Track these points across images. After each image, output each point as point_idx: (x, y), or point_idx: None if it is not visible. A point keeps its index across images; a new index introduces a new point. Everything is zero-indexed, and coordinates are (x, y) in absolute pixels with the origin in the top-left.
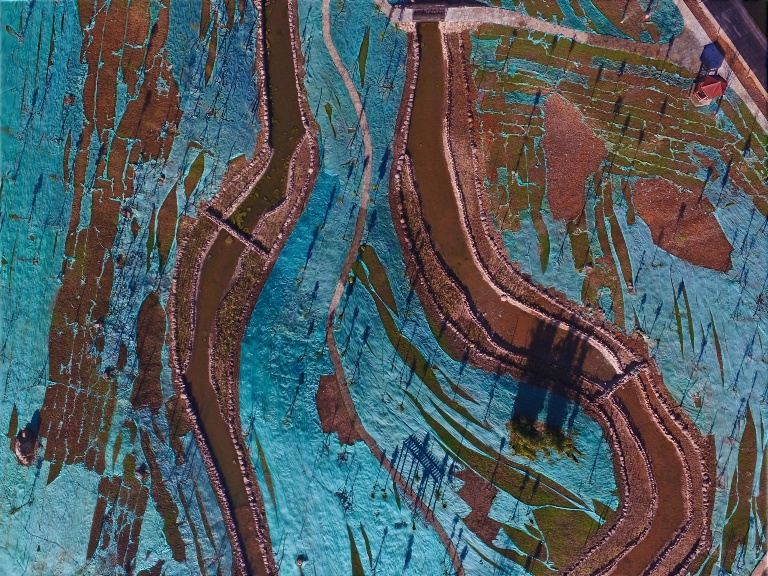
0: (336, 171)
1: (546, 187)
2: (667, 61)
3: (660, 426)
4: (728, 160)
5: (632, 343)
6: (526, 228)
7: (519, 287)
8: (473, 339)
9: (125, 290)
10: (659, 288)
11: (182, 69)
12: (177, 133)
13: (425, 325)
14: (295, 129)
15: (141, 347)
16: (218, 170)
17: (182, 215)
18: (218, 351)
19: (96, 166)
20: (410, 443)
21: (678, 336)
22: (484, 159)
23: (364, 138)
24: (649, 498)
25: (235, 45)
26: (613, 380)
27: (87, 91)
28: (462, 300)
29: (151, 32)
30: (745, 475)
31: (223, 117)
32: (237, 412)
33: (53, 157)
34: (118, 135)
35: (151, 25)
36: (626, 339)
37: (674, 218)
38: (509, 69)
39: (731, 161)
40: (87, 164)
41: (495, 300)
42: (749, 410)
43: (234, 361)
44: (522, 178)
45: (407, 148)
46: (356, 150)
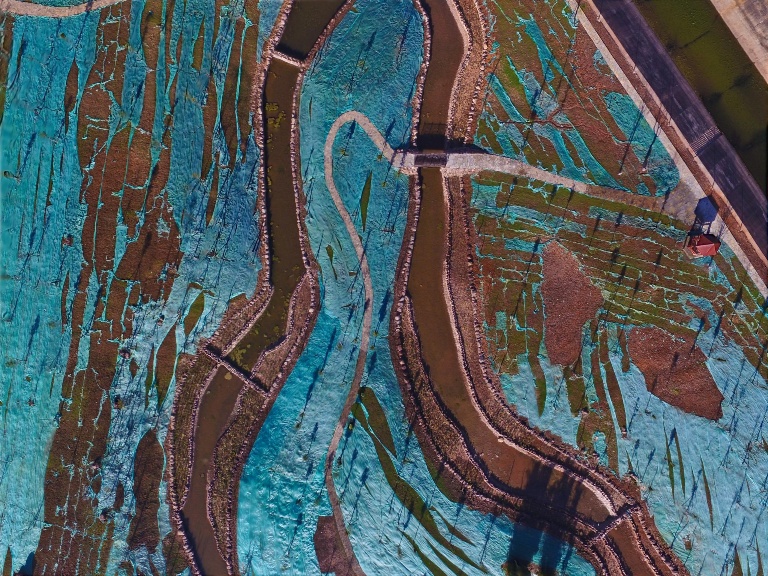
0: (337, 313)
1: (544, 333)
2: (663, 213)
3: (651, 567)
4: (720, 311)
5: (625, 486)
6: (523, 372)
7: (516, 429)
8: (470, 480)
9: (123, 430)
10: (652, 434)
11: (183, 211)
12: (177, 274)
13: (423, 466)
14: (296, 267)
15: (138, 486)
16: (218, 309)
17: (181, 353)
18: (216, 488)
19: (94, 308)
20: None
21: (670, 481)
22: (483, 303)
23: (365, 281)
24: None
25: (237, 185)
26: (606, 521)
27: (86, 232)
28: (460, 441)
29: (152, 173)
30: None
31: (224, 257)
32: (234, 549)
33: (50, 298)
34: (117, 276)
35: (152, 166)
36: (619, 482)
37: (667, 366)
38: (509, 216)
39: (723, 312)
40: (85, 306)
41: (492, 441)
42: (737, 554)
43: (232, 499)
44: (520, 323)
45: (407, 289)
46: (357, 293)
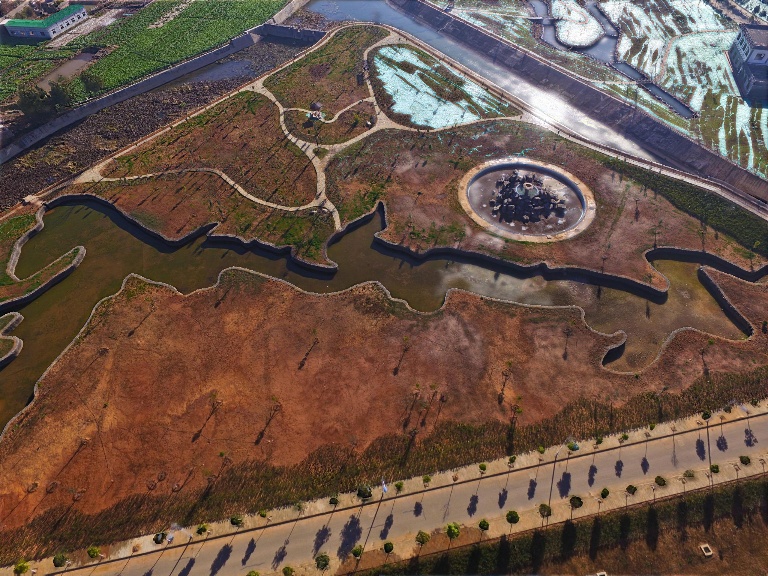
0: None
1: None
2: None
3: None
4: None
5: None
6: None
7: None
8: None
9: None
10: None
11: None
12: None
13: None
14: (588, 8)
15: None
16: None
17: None
18: None
19: None
20: None
21: None
22: None
23: None
24: None
25: None
26: None
27: None
28: None
29: None
30: None
31: None
32: None
33: None
34: None
35: None
36: None
37: None
38: None
39: None
40: None
41: None
42: None
43: None
44: None
45: None
46: None
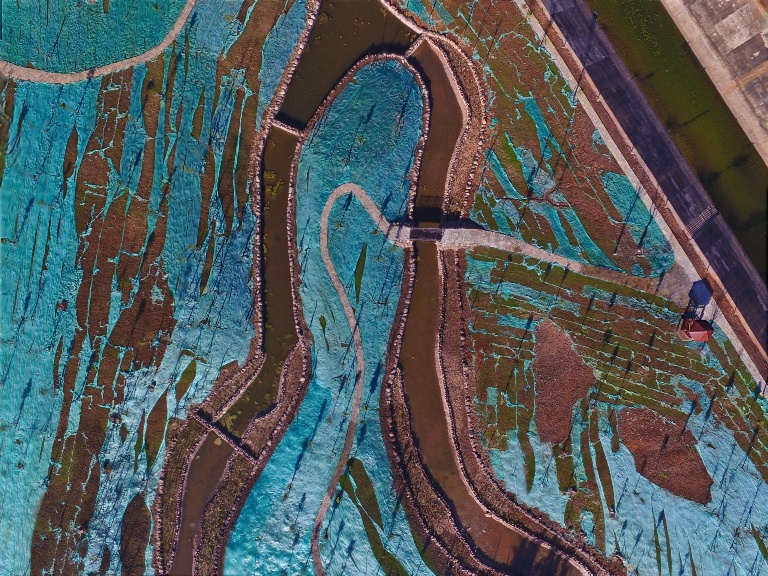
0: (328, 384)
1: (534, 410)
2: (657, 295)
3: None
4: (712, 395)
5: (612, 566)
6: (513, 448)
7: (504, 505)
8: (456, 555)
9: (111, 495)
10: (640, 515)
11: (178, 278)
12: (170, 341)
13: (410, 539)
14: (289, 335)
15: (125, 550)
16: (210, 375)
17: (172, 419)
18: (202, 553)
19: (87, 373)
20: None
21: (656, 563)
22: (475, 377)
23: (357, 353)
24: None
25: (232, 252)
26: None
27: (81, 297)
28: (447, 515)
29: (148, 241)
30: None
31: (217, 325)
32: None
33: (43, 362)
34: (110, 342)
35: (148, 233)
36: (606, 562)
37: (657, 448)
38: (503, 292)
39: (715, 396)
40: (78, 371)
41: (480, 515)
42: None
43: (218, 565)
44: (511, 399)
45: (399, 360)
46: (348, 364)
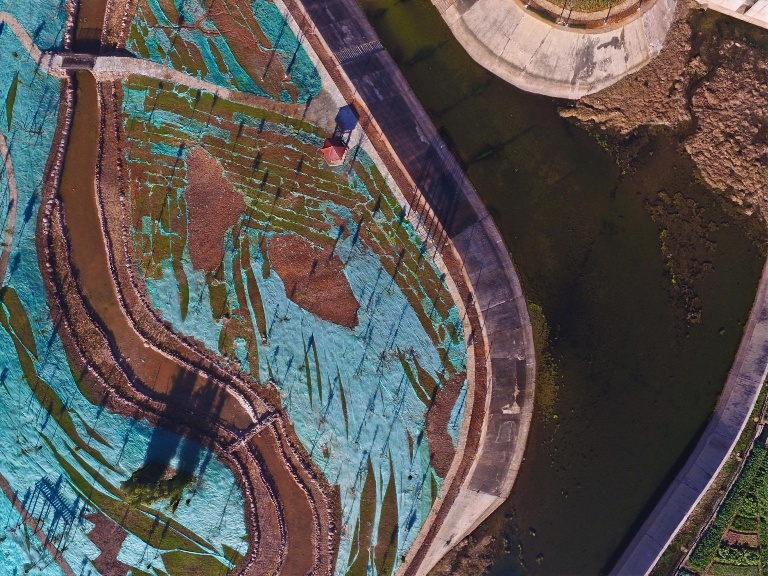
0: None
1: (187, 238)
2: (304, 121)
3: (292, 474)
4: (359, 220)
5: (266, 393)
6: (167, 277)
7: (161, 334)
8: (113, 384)
9: None
10: (291, 341)
11: None
12: None
13: (66, 368)
14: None
15: None
16: None
17: None
18: None
19: None
20: (42, 485)
21: (307, 388)
22: (131, 207)
23: (9, 181)
24: (279, 544)
25: None
26: (248, 428)
27: None
28: (105, 345)
29: None
30: (366, 525)
31: None
32: None
33: None
34: None
35: None
36: (260, 389)
37: (306, 273)
38: (155, 120)
39: (361, 221)
40: None
41: (139, 346)
42: (370, 462)
43: None
44: (165, 228)
45: (59, 192)
46: (1, 193)
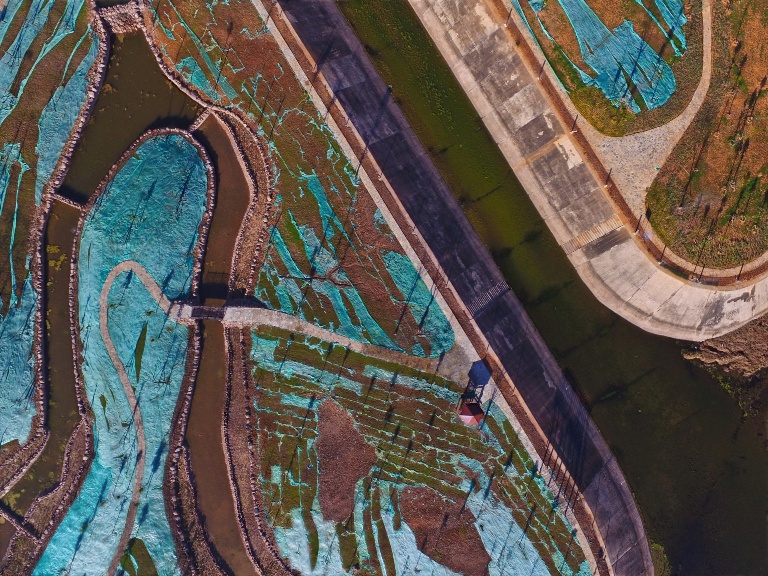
0: (109, 463)
1: (317, 488)
2: (437, 375)
3: None
4: (491, 473)
5: None
6: (297, 527)
7: None
8: None
9: None
10: None
11: None
12: None
13: None
14: (73, 413)
15: None
16: None
17: None
18: None
19: None
20: None
21: None
22: (259, 456)
23: (138, 433)
24: None
25: (10, 330)
26: None
27: None
28: None
29: None
30: None
31: None
32: None
33: None
34: None
35: None
36: None
37: (437, 526)
38: (285, 371)
39: (493, 474)
40: None
41: None
42: None
43: None
44: (294, 478)
45: (185, 438)
46: (129, 444)
